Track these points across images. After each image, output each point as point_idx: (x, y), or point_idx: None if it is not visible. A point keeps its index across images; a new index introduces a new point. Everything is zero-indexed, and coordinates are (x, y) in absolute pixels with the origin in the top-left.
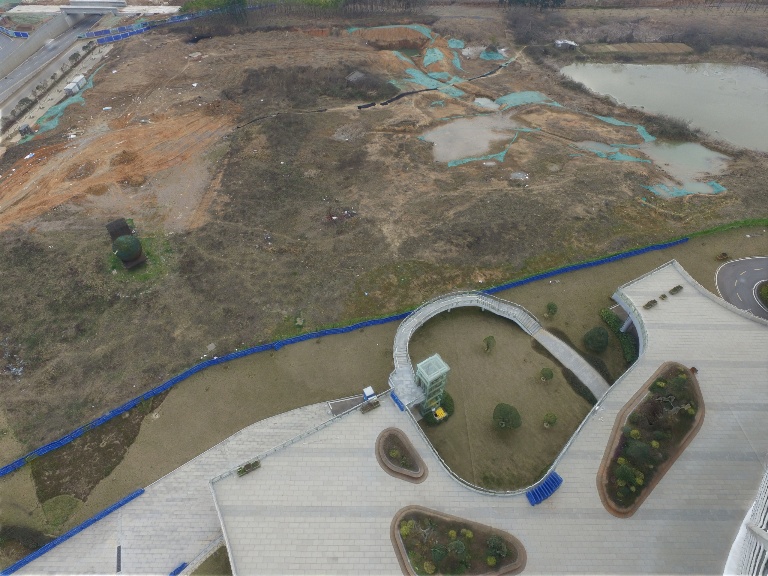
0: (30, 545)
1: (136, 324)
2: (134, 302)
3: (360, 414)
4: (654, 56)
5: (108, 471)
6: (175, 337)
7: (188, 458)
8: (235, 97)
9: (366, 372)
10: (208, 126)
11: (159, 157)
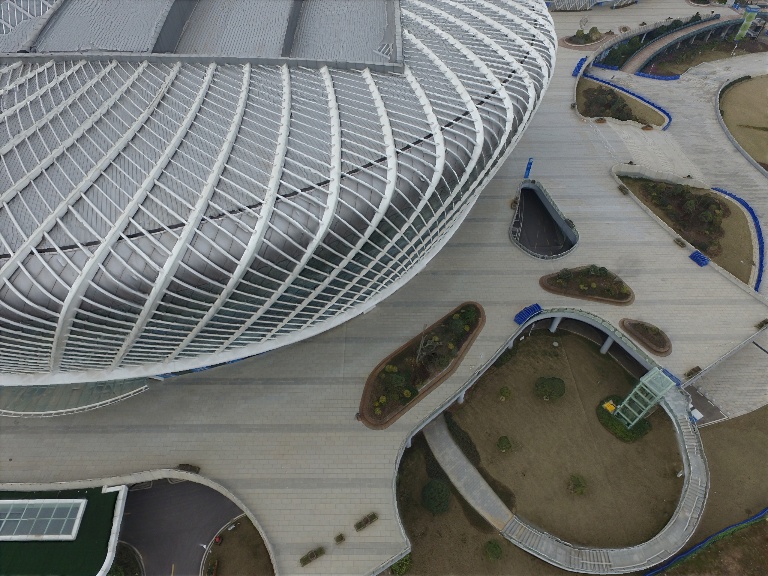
0: None
1: None
2: None
3: None
4: None
5: None
6: None
7: None
8: None
9: (708, 453)
10: None
11: None
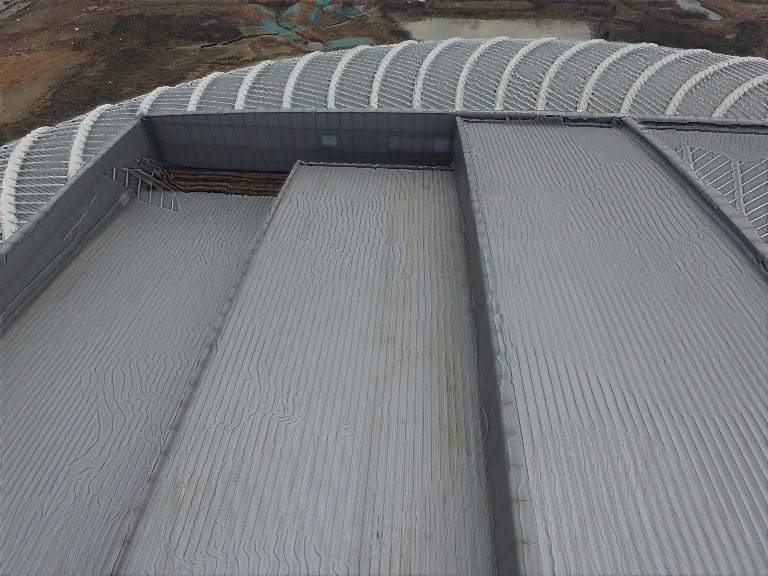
0: None
1: None
2: None
3: None
4: (493, 11)
5: None
6: None
7: None
8: (101, 37)
9: None
10: (68, 58)
11: (16, 78)
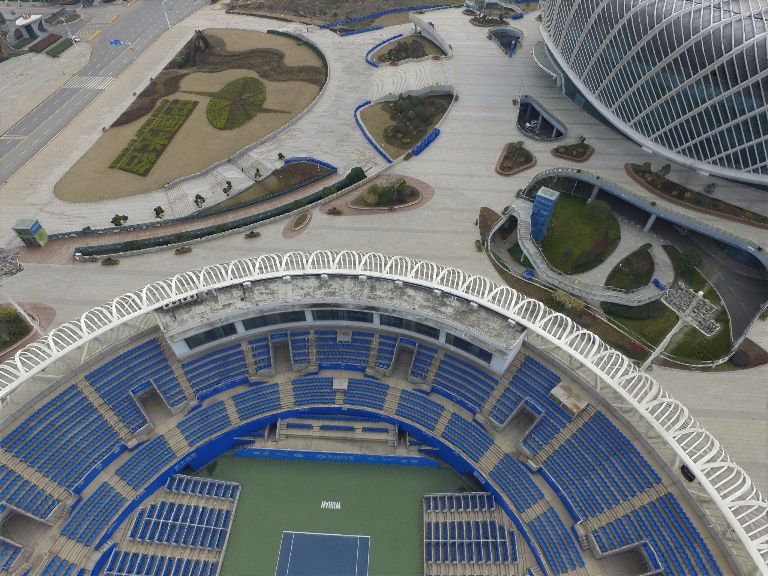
0: (354, 30)
1: (360, 5)
2: (356, 1)
3: (455, 8)
4: None
5: (369, 25)
6: (377, 7)
7: (394, 25)
8: None
9: None
10: None
11: None
